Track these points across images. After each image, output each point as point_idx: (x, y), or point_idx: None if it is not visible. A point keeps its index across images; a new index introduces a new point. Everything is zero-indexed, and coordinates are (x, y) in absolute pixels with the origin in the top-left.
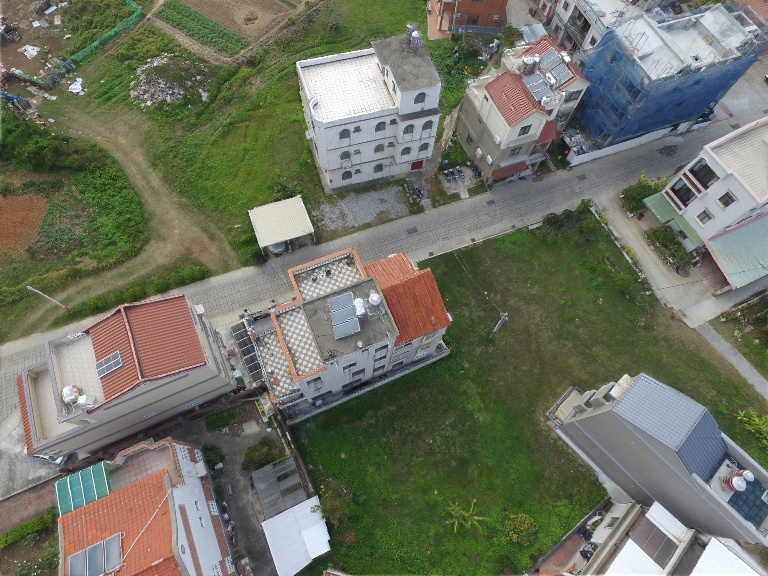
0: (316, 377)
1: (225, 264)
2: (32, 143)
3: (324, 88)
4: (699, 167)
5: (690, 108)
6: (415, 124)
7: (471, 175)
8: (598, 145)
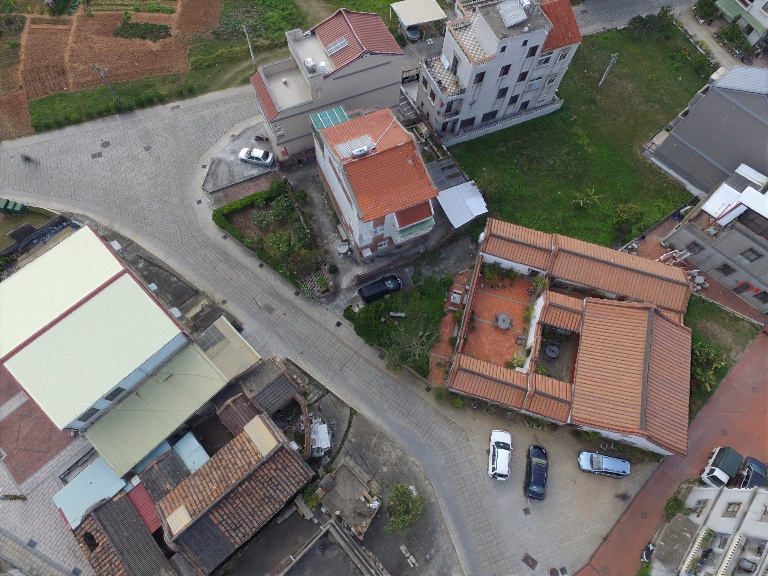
0: (483, 71)
1: None
2: None
3: None
4: None
5: None
6: None
7: None
8: None
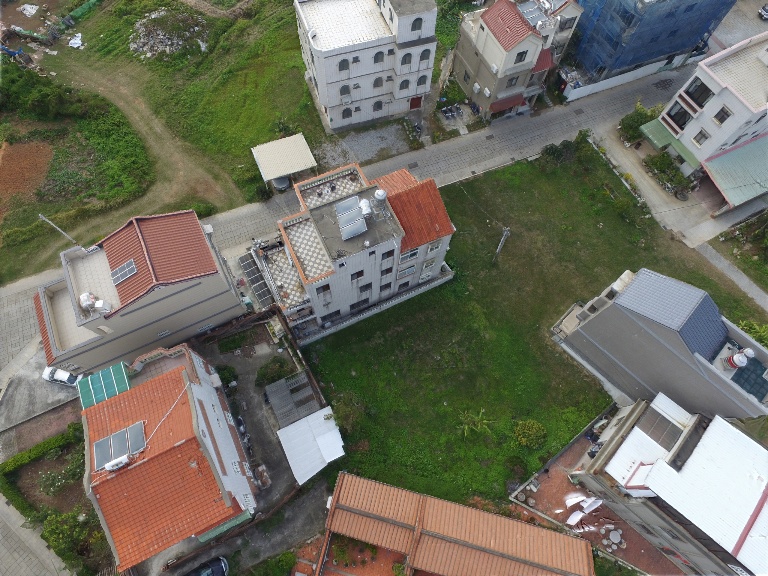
0: (325, 284)
1: (230, 201)
2: (36, 92)
3: (322, 21)
4: (694, 88)
5: (684, 37)
6: (413, 53)
7: (469, 112)
8: (594, 79)
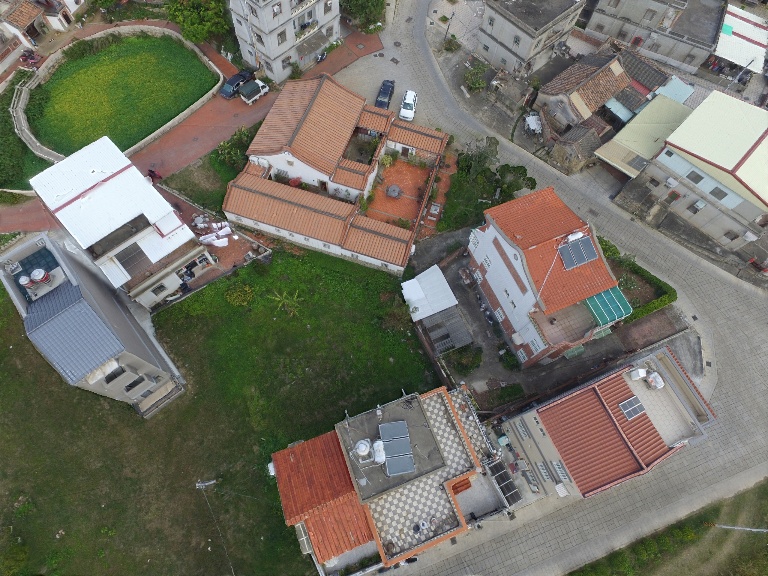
0: None
1: None
2: None
3: None
4: None
5: None
6: None
7: None
8: None
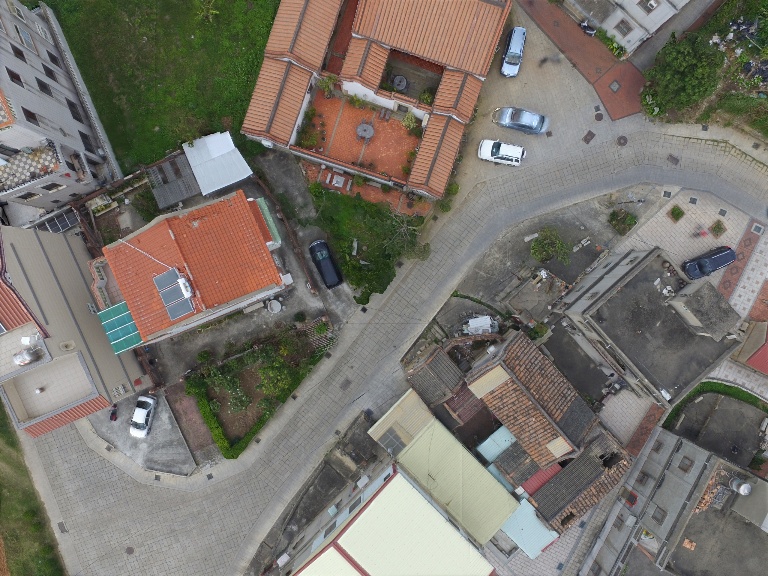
0: (21, 110)
1: None
2: None
3: None
4: None
5: None
6: None
7: None
8: None
